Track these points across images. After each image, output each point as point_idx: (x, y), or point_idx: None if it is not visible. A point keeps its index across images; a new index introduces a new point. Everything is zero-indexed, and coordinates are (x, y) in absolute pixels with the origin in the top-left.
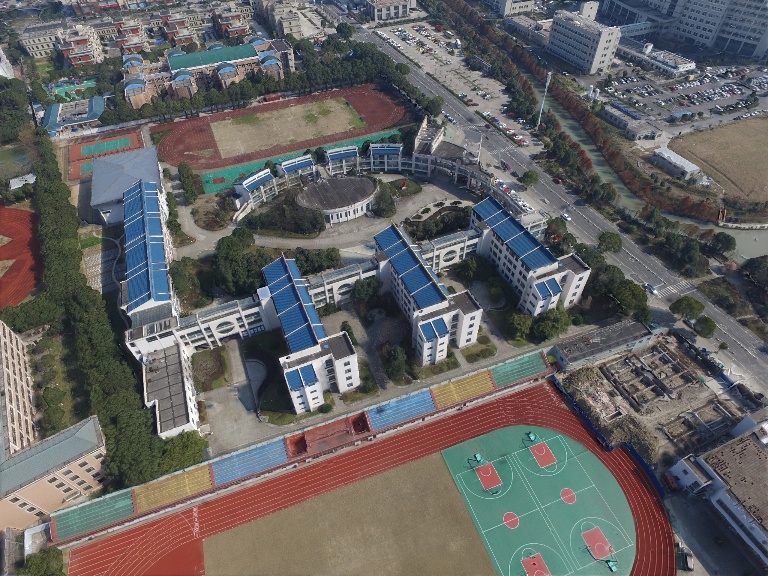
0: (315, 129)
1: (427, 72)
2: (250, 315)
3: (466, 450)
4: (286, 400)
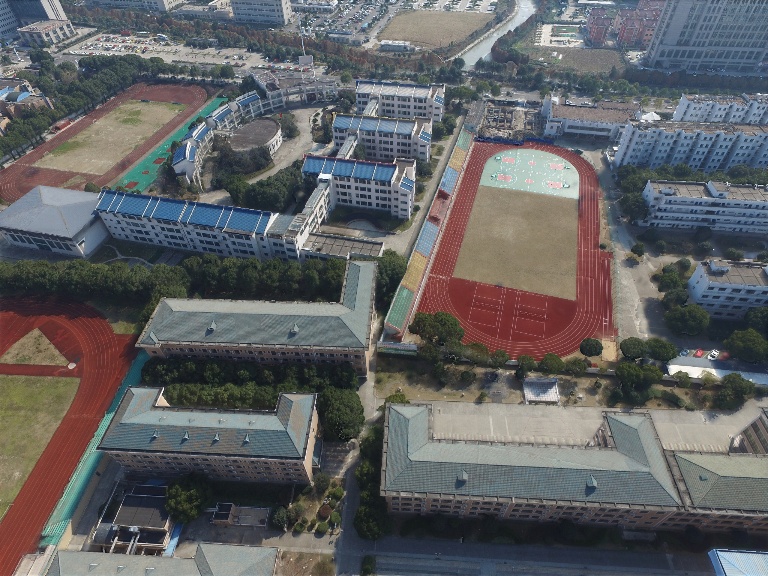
0: (149, 124)
1: (173, 60)
2: (326, 196)
3: (486, 178)
4: (394, 220)
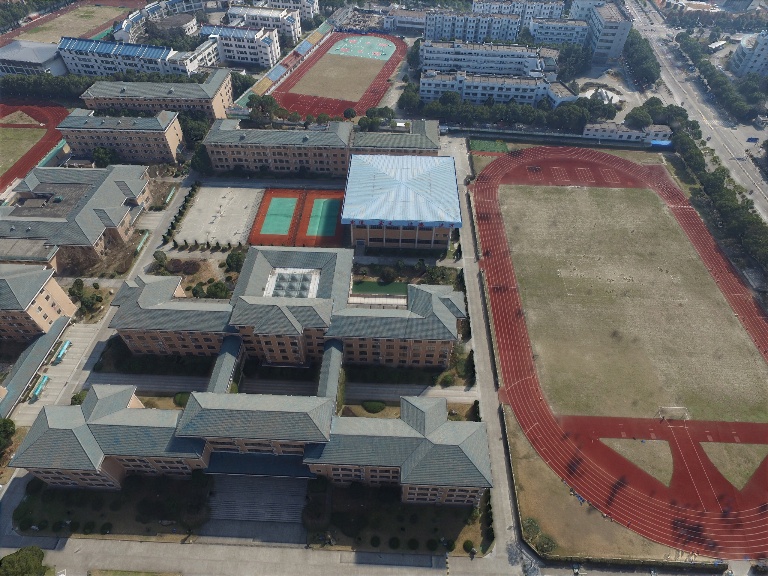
0: (100, 18)
1: None
2: None
3: None
4: (262, 68)
